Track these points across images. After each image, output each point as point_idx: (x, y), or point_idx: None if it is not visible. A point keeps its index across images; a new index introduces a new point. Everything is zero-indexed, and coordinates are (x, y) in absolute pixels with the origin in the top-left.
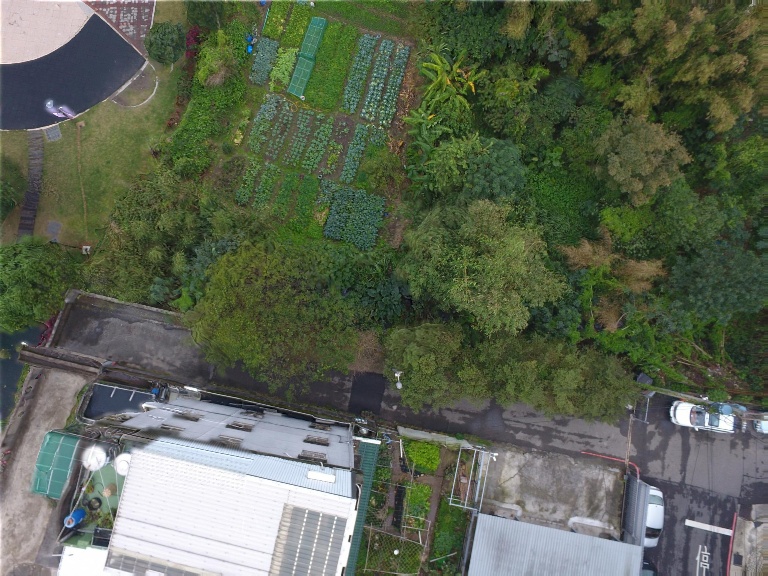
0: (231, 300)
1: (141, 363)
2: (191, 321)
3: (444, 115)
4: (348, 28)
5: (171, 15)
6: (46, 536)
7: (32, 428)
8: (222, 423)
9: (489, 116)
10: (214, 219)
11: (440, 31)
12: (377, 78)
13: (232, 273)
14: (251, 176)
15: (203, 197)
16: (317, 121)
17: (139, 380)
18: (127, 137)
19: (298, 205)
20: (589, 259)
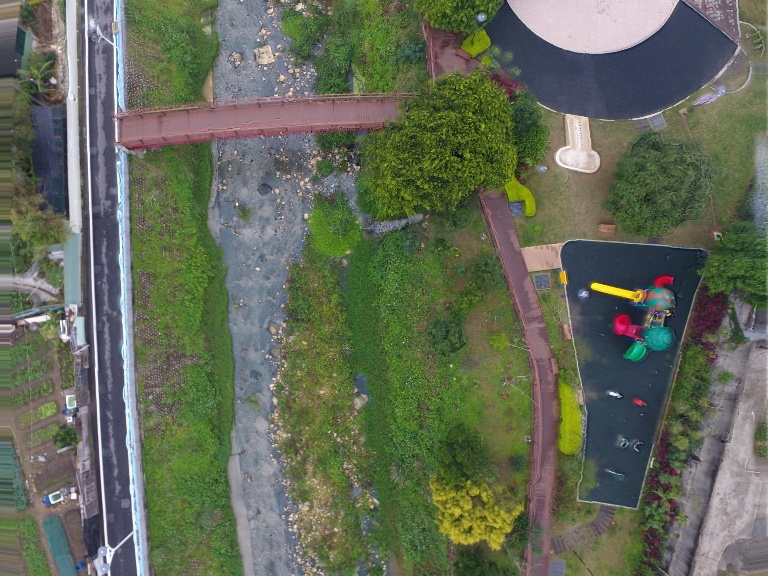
0: None
1: None
2: None
3: None
4: None
5: None
6: (759, 513)
7: None
8: None
9: None
10: None
11: None
12: None
13: None
14: None
15: None
16: None
17: None
18: (737, 123)
19: None
20: None
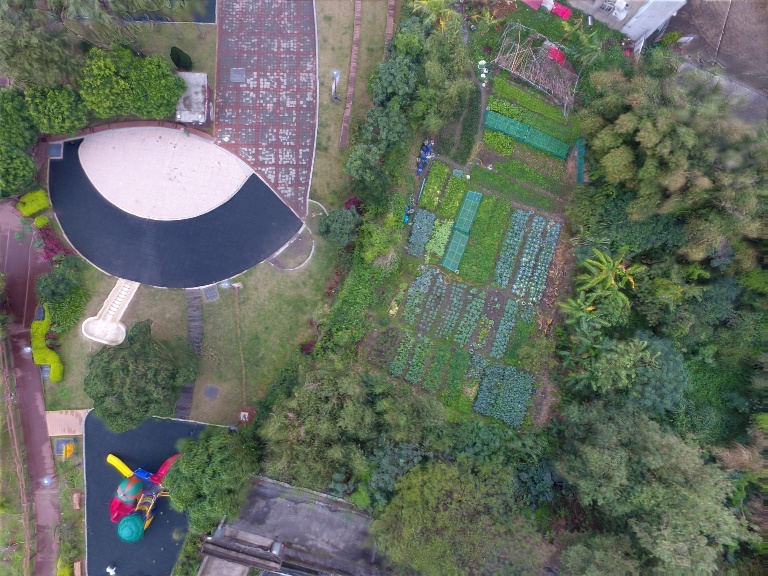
0: (427, 523)
1: (306, 544)
2: (378, 530)
3: (606, 312)
4: (502, 203)
5: (328, 178)
6: None
7: None
8: None
9: (644, 308)
10: (390, 415)
11: (600, 221)
12: (529, 254)
13: (429, 497)
14: (405, 348)
15: (357, 366)
16: (470, 295)
17: None
18: (285, 302)
19: (449, 379)
20: (744, 466)
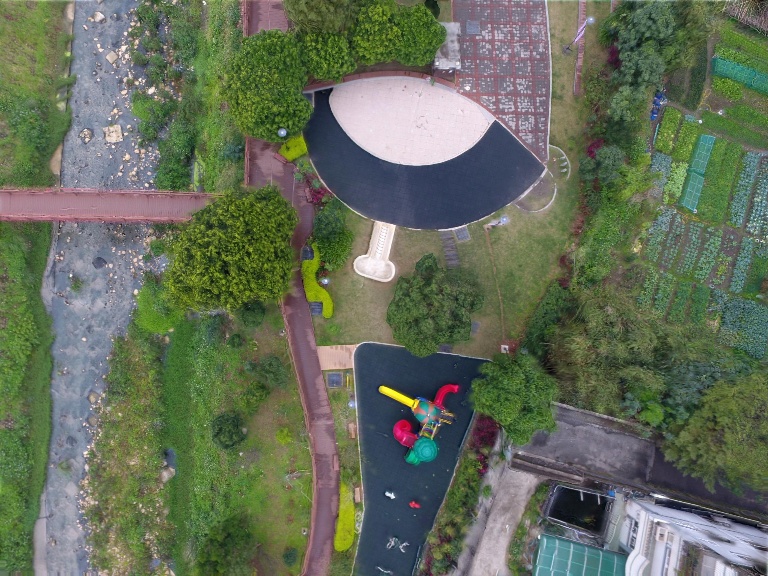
0: (744, 429)
1: (586, 464)
2: (685, 441)
3: None
4: (733, 146)
5: (566, 125)
6: None
7: (489, 522)
8: (742, 542)
9: None
10: (671, 338)
11: None
12: (760, 195)
13: (745, 405)
14: (651, 284)
15: None
16: (707, 233)
17: (587, 481)
18: (535, 242)
19: (692, 312)
20: None
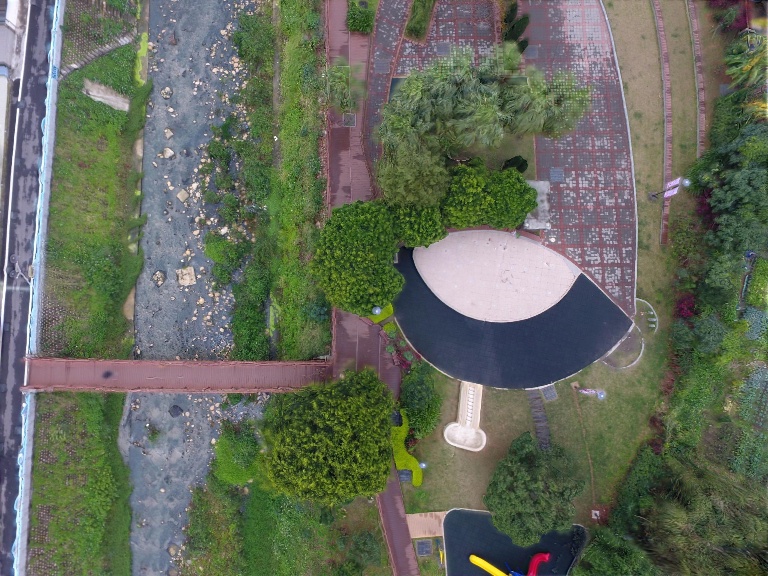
0: None
1: None
2: None
3: None
4: None
5: (653, 276)
6: None
7: None
8: None
9: None
10: None
11: None
12: None
13: None
14: (742, 444)
15: (696, 462)
16: None
17: None
18: (624, 401)
19: None
20: None
